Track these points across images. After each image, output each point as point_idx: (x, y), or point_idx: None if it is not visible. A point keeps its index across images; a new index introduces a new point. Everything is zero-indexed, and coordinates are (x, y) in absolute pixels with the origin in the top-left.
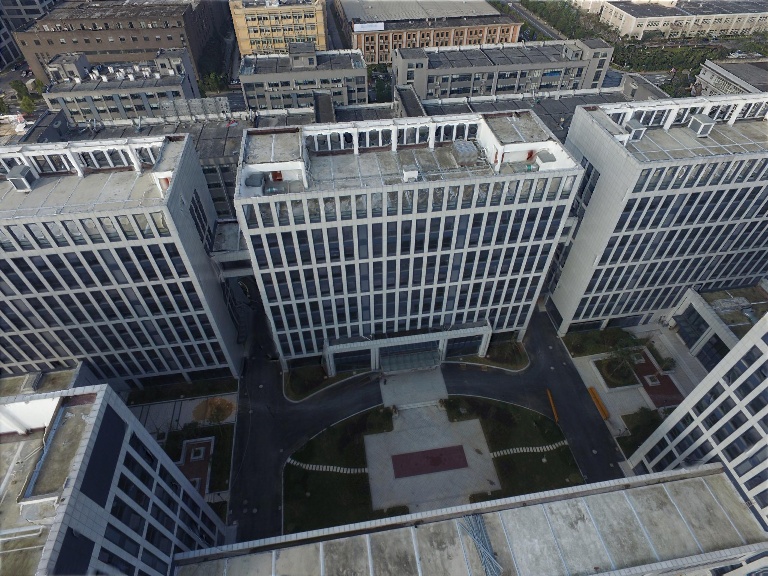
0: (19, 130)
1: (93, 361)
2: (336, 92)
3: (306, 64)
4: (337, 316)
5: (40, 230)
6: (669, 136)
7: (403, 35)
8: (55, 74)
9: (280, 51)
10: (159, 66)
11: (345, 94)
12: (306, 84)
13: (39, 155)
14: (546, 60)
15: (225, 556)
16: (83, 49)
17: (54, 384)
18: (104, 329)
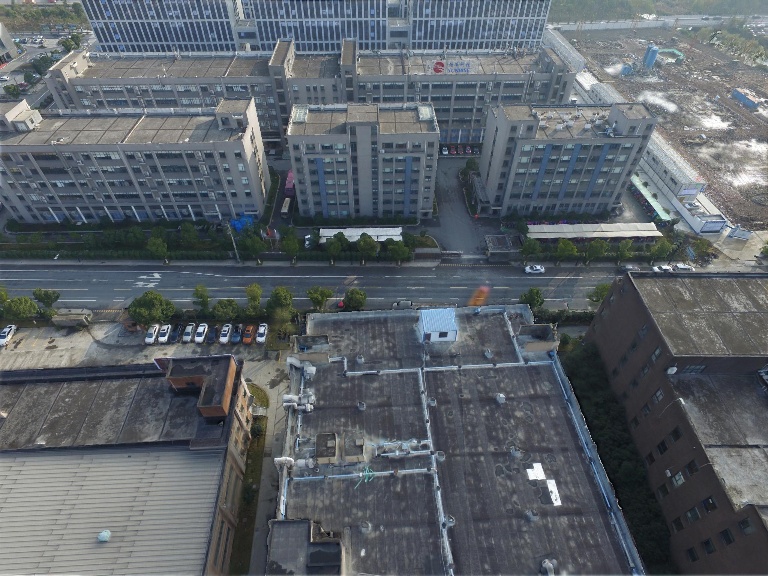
0: None
1: None
2: None
3: None
4: None
5: None
6: None
7: None
8: None
9: None
10: None
11: None
12: None
13: None
14: (69, 123)
15: (390, 5)
16: None
17: None
18: None
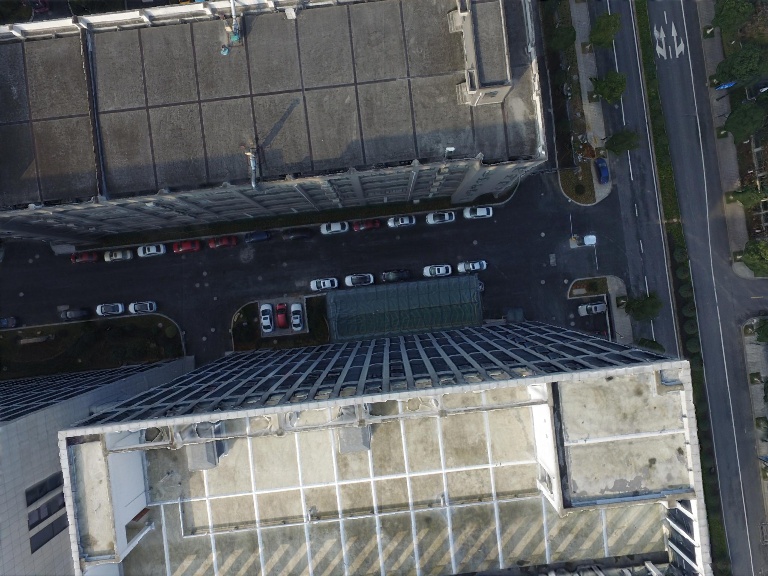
0: None
1: None
2: None
3: None
4: None
5: None
6: (291, 437)
7: None
8: None
9: None
10: None
11: None
12: None
13: None
14: None
15: None
16: None
17: None
18: None
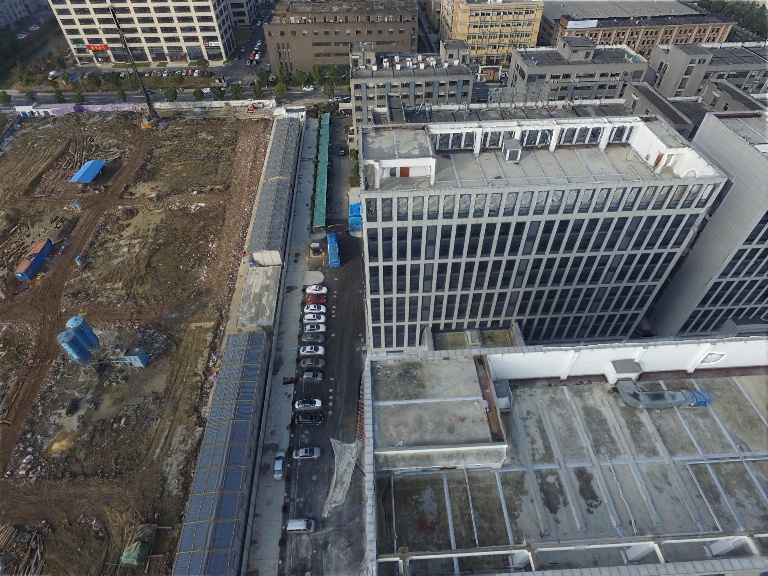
0: (276, 114)
1: (525, 323)
2: (611, 85)
3: (582, 58)
4: (760, 296)
5: (569, 196)
6: None
7: (613, 33)
8: (354, 62)
9: (492, 46)
10: (447, 56)
11: (620, 88)
12: (585, 77)
13: (524, 130)
14: None
15: None
16: (320, 40)
17: (492, 341)
18: (563, 293)
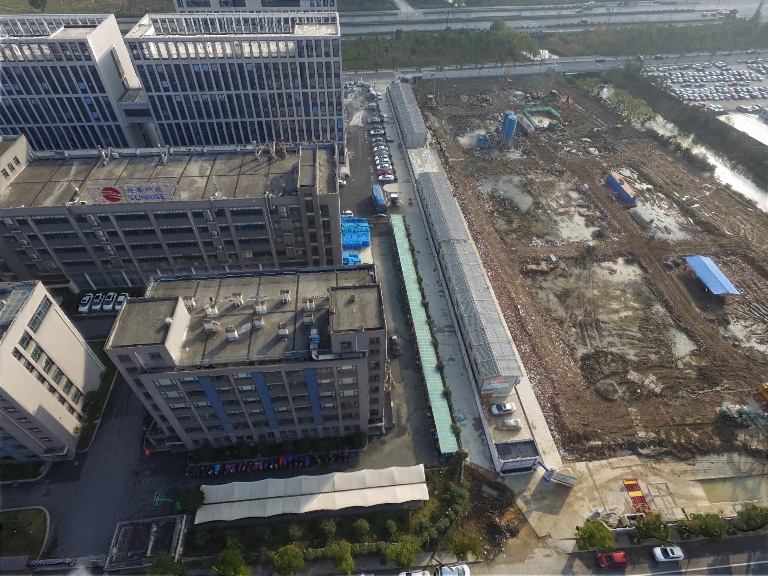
0: None
1: None
2: None
3: None
4: None
5: None
6: None
7: None
8: None
9: None
10: None
11: None
12: None
13: None
14: None
15: None
16: None
17: None
18: None
